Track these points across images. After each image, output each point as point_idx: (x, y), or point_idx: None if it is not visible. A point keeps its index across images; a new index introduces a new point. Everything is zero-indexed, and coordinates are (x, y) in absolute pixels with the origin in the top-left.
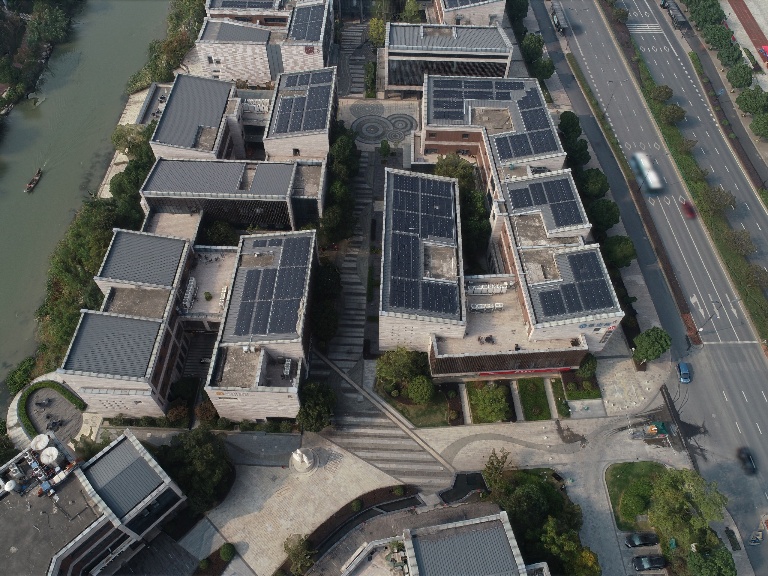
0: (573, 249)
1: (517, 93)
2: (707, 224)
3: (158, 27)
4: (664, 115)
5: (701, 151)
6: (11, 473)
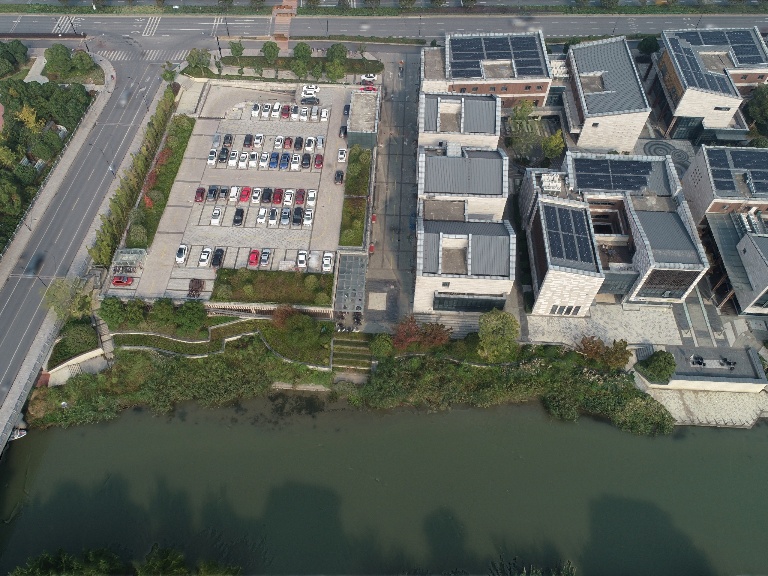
0: None
1: (683, 44)
2: (709, 13)
3: (497, 422)
4: (615, 3)
5: (629, 2)
6: None
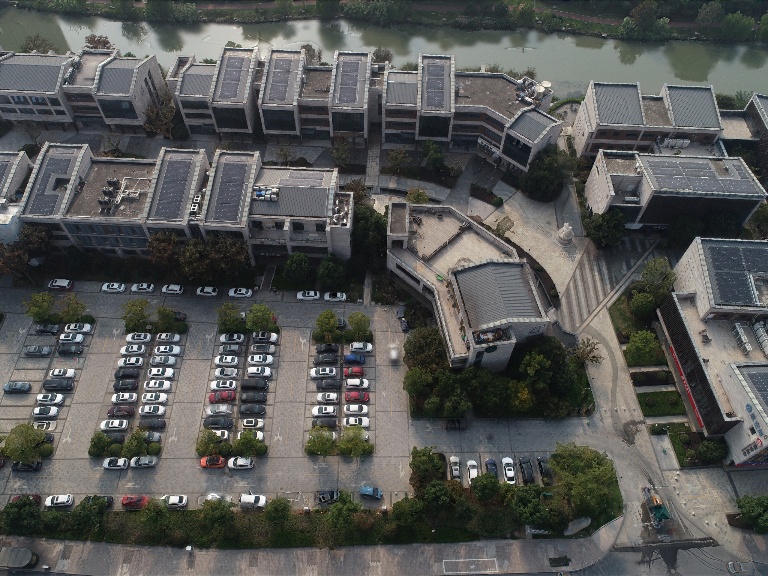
0: None
1: None
2: None
3: None
4: None
5: None
6: None
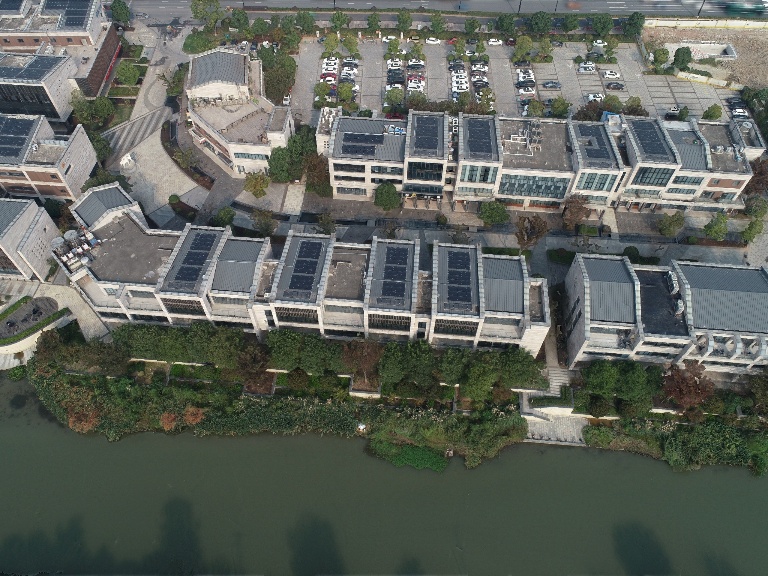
0: (41, 4)
1: None
2: None
3: None
4: None
5: None
6: (74, 271)
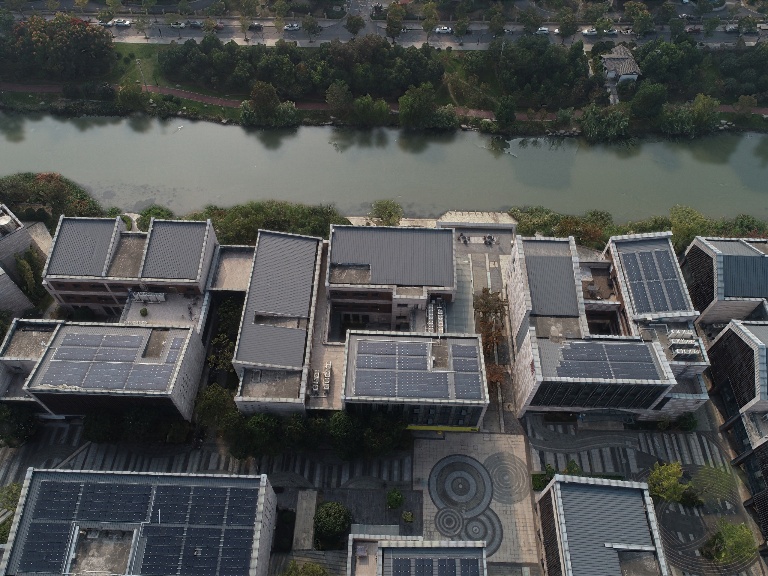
0: None
1: None
2: None
3: (647, 214)
4: None
5: None
6: None
